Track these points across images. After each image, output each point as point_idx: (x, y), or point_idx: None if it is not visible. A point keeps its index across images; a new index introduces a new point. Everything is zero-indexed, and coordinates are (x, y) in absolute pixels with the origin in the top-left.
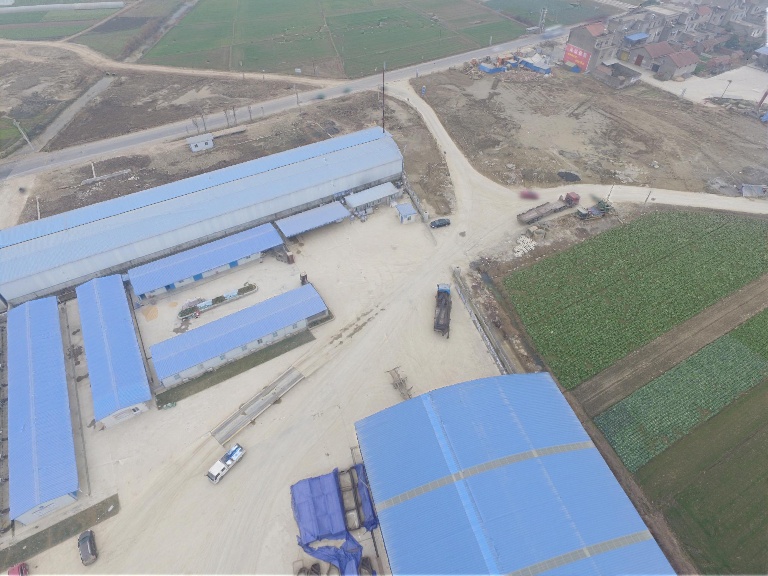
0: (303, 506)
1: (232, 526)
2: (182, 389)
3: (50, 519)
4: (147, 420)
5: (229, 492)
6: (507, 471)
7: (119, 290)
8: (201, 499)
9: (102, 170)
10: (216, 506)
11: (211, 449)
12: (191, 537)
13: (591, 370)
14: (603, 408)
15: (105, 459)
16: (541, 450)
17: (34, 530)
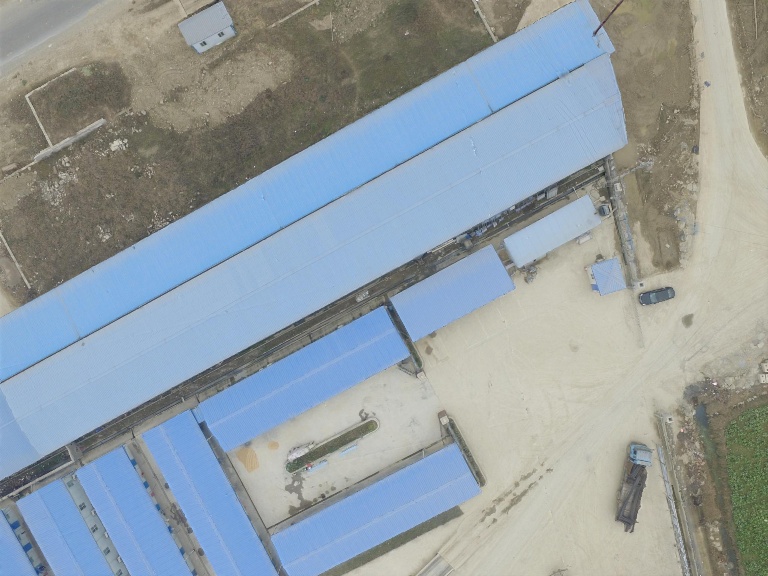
0: None
1: None
2: None
3: None
4: None
5: None
6: None
7: (200, 443)
8: None
9: (54, 124)
10: None
11: None
12: None
13: None
14: None
15: None
16: None
17: None
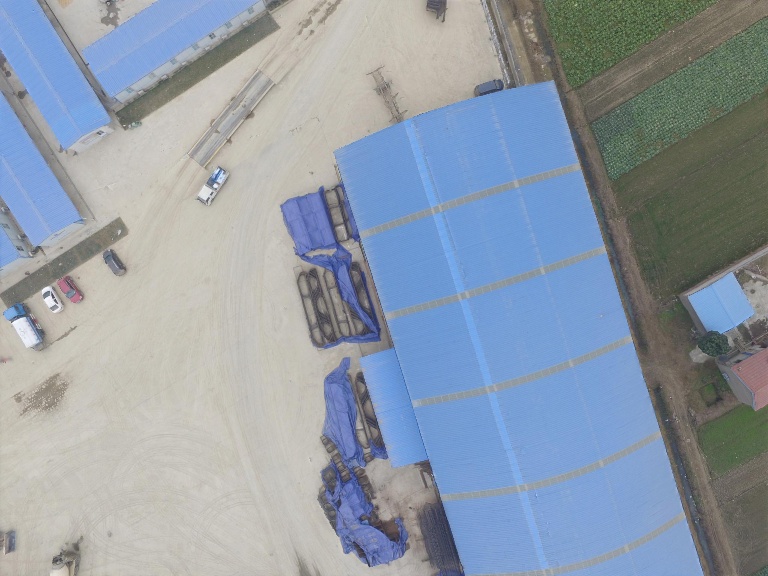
0: (295, 223)
1: (234, 241)
2: (141, 104)
3: (70, 241)
4: (117, 142)
5: (223, 212)
6: (485, 204)
7: None
8: (199, 219)
9: None
10: (215, 225)
11: (194, 172)
12: (201, 251)
13: (608, 61)
14: (606, 110)
15: (93, 185)
16: (523, 180)
17: (61, 250)
